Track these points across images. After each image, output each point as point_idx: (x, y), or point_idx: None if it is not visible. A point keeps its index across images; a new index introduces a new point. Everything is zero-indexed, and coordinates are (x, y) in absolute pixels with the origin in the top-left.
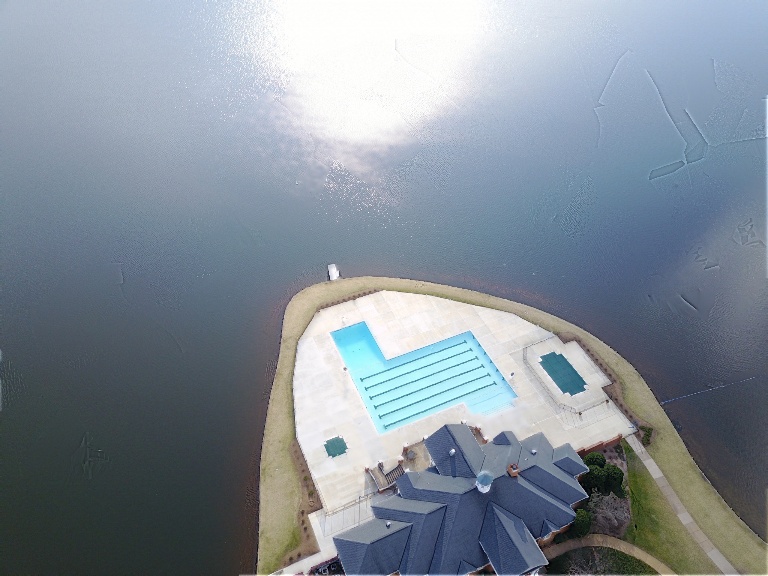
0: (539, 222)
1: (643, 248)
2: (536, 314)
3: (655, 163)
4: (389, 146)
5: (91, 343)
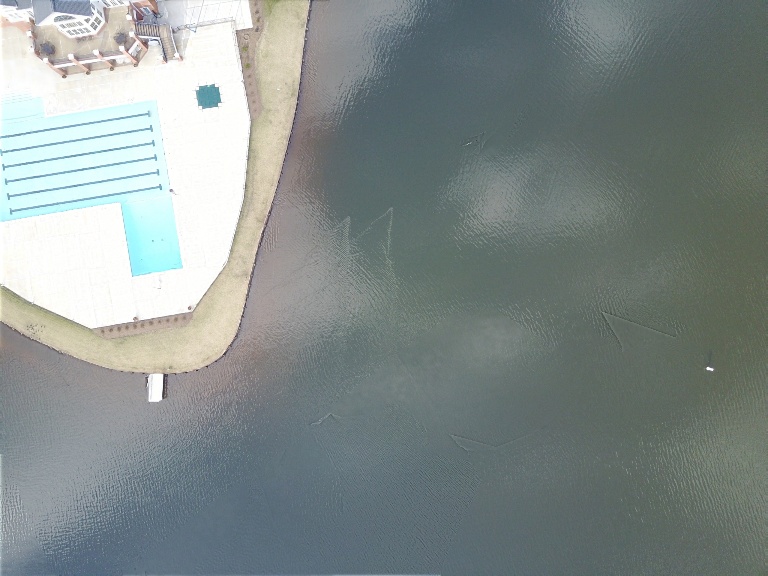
0: None
1: None
2: None
3: None
4: None
5: (514, 391)
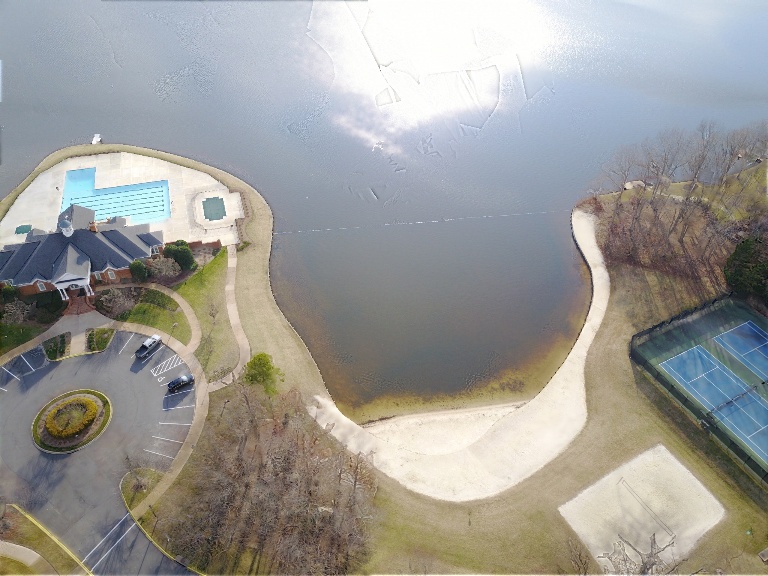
0: (285, 129)
1: (352, 152)
2: (225, 176)
3: (373, 88)
4: (166, 55)
5: None
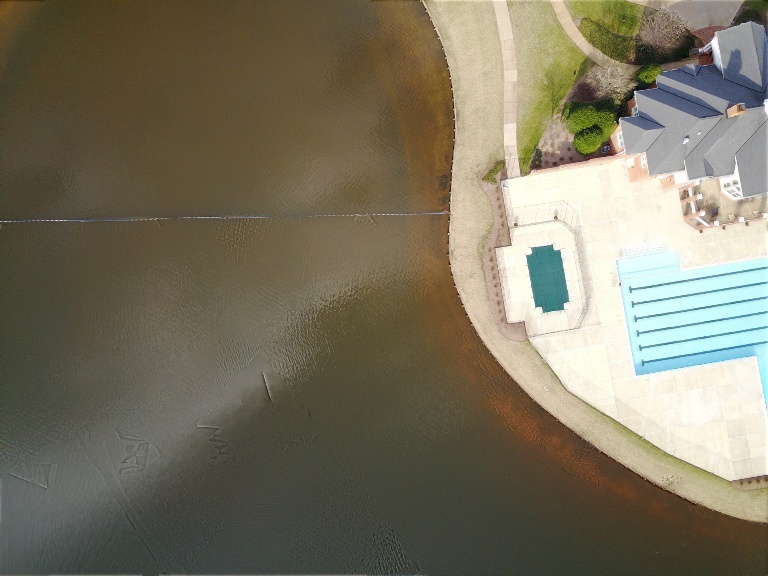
0: None
1: (294, 486)
2: (535, 383)
3: None
4: None
5: None
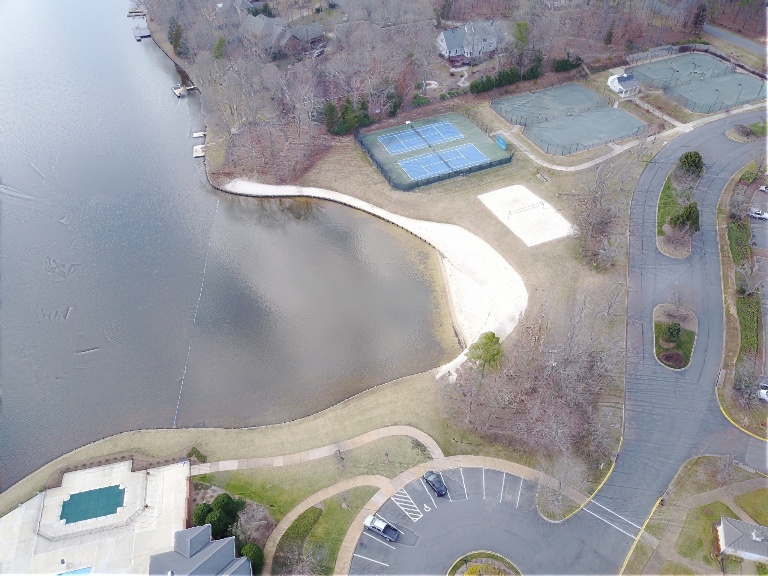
0: None
1: (3, 354)
2: (3, 501)
3: None
4: None
5: None
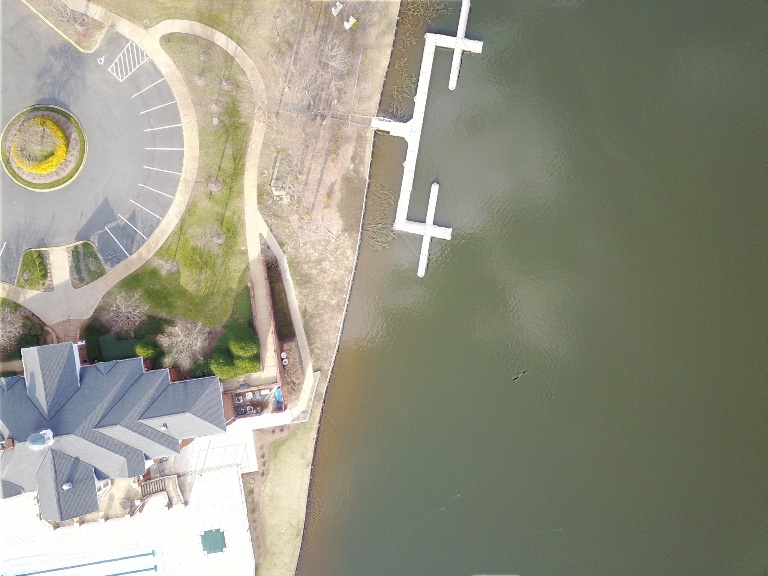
0: None
1: None
2: None
3: None
4: None
5: None
